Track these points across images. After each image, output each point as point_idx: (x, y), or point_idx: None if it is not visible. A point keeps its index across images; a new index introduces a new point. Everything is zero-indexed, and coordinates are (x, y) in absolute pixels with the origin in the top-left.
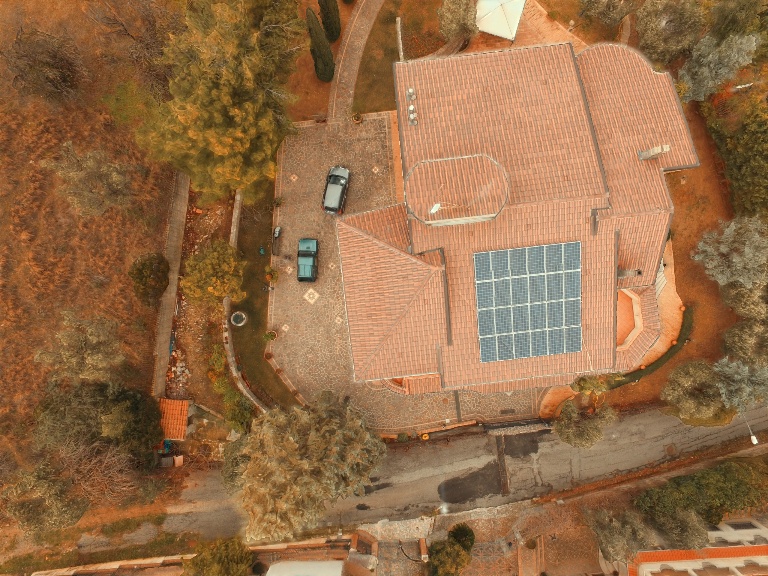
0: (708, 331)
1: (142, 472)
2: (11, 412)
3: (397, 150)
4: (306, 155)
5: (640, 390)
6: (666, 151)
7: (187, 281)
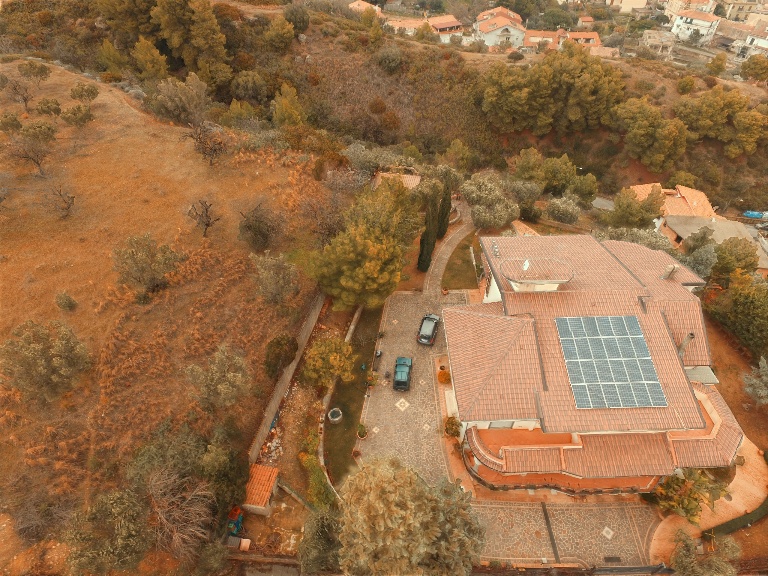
0: None
1: (213, 533)
2: (112, 450)
3: None
4: (406, 309)
5: (759, 543)
6: (677, 268)
7: (315, 350)
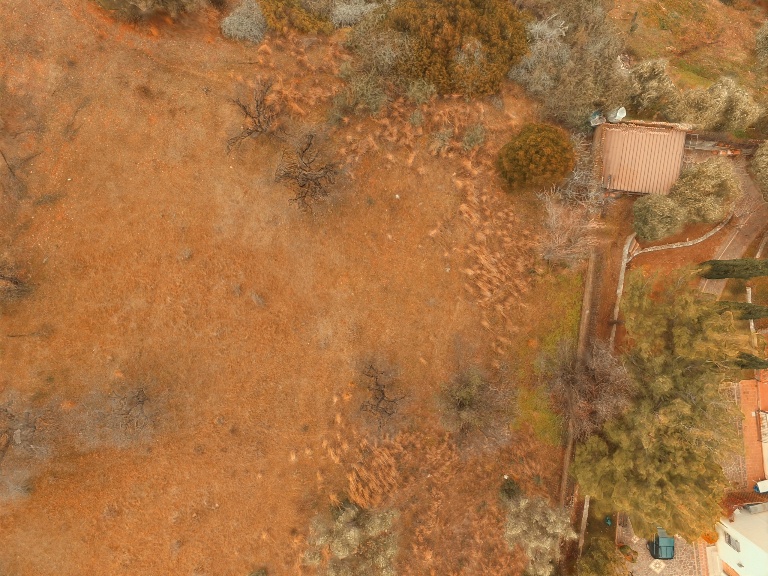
0: None
1: None
2: None
3: (746, 420)
4: None
5: None
6: None
7: None
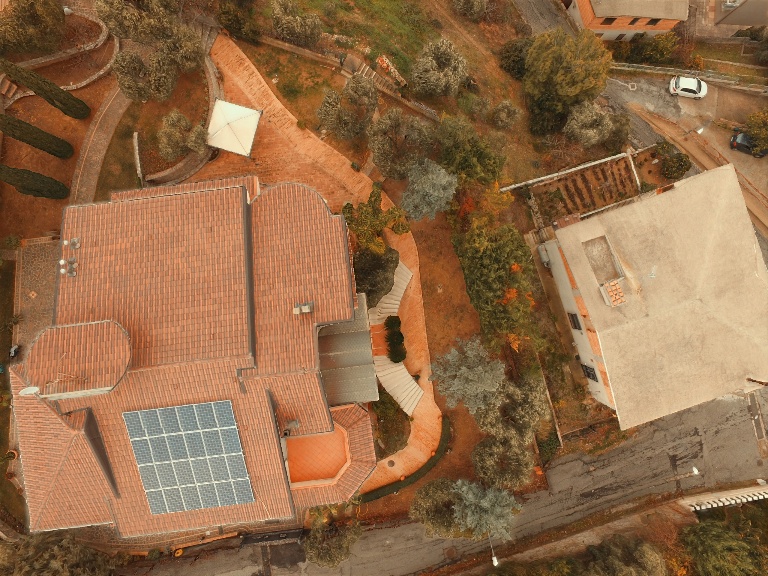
0: (470, 440)
1: None
2: None
3: None
4: (45, 272)
5: (403, 500)
6: None
7: None
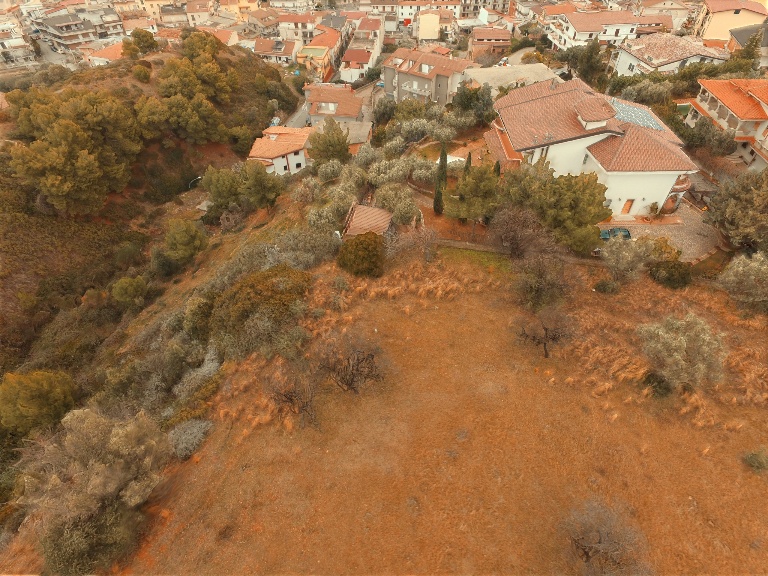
0: None
1: None
2: None
3: None
4: None
5: None
6: None
7: None
